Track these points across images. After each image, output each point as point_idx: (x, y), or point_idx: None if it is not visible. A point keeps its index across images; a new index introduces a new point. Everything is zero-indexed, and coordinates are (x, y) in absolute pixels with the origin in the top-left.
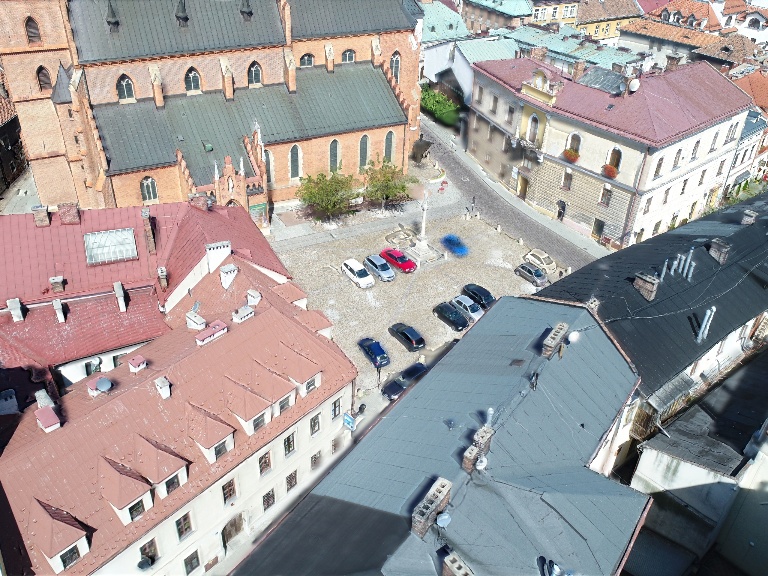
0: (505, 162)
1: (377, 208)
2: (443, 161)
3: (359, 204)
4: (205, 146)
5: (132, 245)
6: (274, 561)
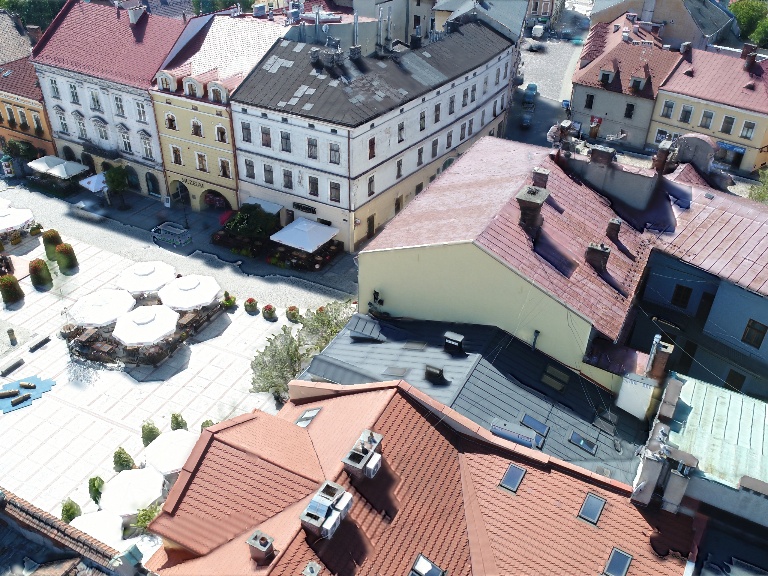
0: None
1: None
2: None
3: None
4: None
5: None
6: None
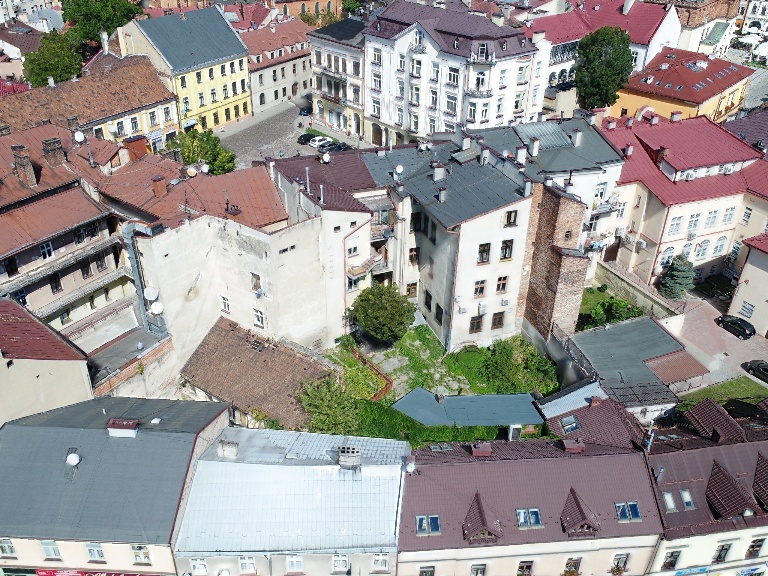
0: None
1: None
2: None
3: None
4: (246, 1)
5: (237, 17)
6: None
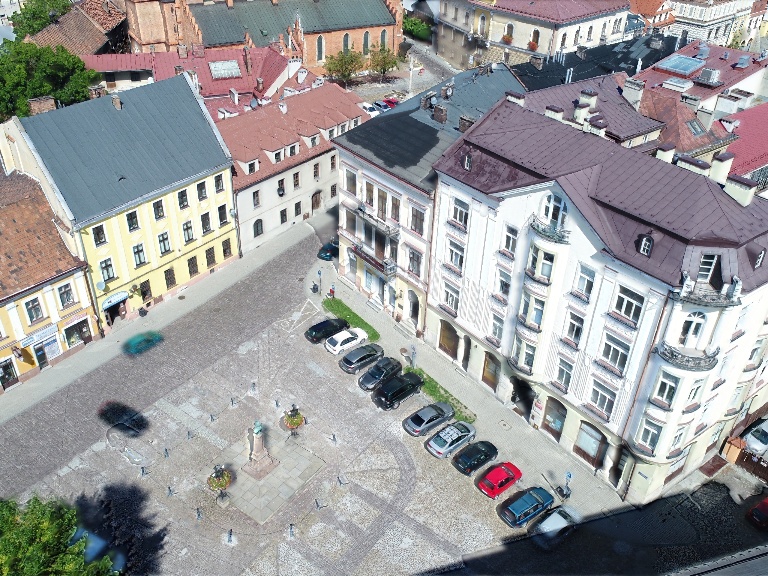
0: (464, 54)
1: (377, 82)
2: (420, 60)
3: (364, 80)
4: (263, 32)
5: (238, 69)
6: (361, 127)
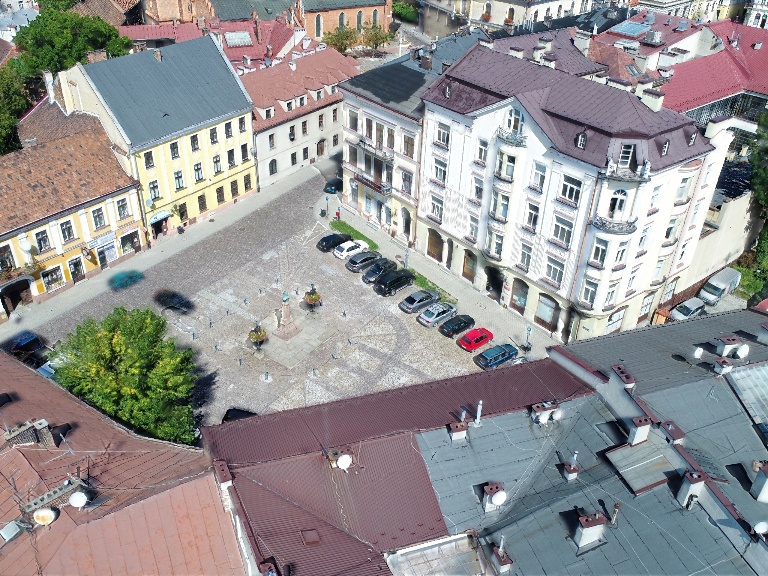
0: (448, 32)
1: (370, 57)
2: (408, 38)
3: (358, 55)
4: (268, 10)
5: (249, 39)
6: None
